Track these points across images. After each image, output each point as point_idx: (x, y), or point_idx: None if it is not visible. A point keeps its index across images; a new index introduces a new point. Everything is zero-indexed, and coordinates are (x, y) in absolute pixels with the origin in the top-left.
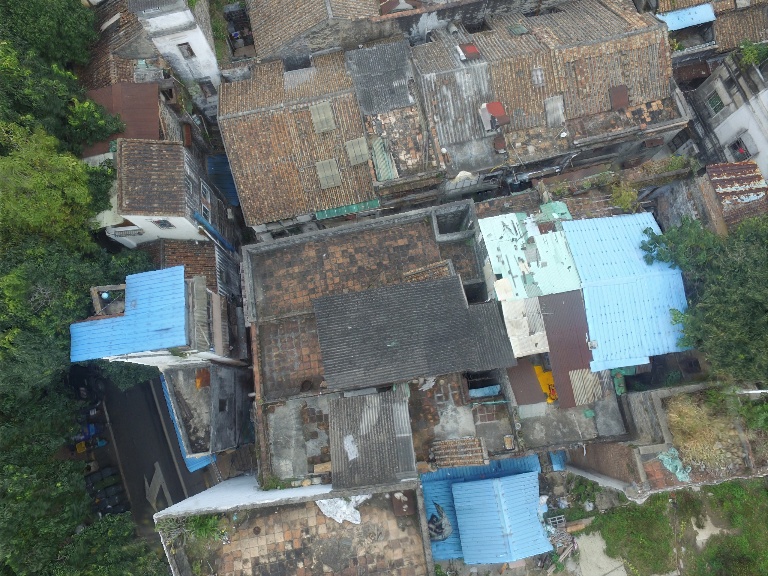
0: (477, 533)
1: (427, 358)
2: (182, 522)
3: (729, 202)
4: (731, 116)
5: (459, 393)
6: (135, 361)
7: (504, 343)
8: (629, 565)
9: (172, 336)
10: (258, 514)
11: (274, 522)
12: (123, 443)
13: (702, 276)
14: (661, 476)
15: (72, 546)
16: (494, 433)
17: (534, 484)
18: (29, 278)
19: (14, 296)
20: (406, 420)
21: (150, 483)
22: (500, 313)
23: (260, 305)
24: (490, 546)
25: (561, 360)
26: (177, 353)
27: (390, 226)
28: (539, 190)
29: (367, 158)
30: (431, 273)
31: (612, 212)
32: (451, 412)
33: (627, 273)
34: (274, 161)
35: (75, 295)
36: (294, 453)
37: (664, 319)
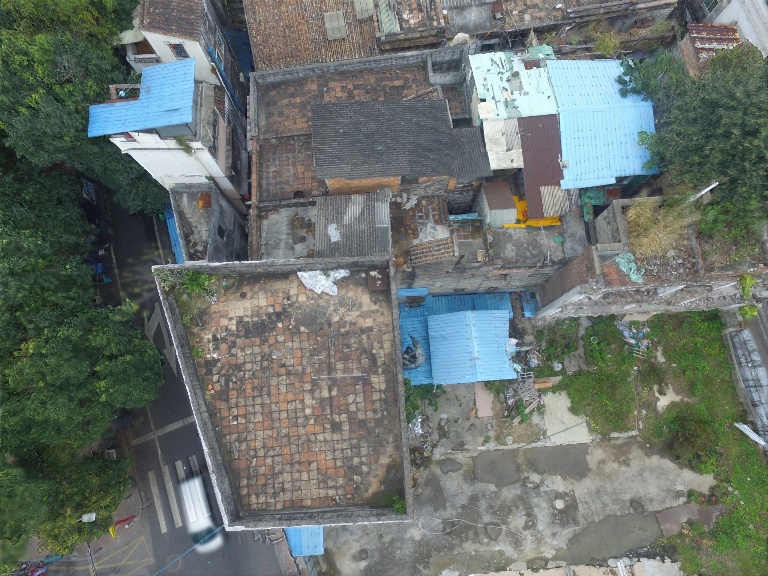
0: (447, 358)
1: (410, 163)
2: (177, 273)
3: (706, 56)
4: (723, 11)
5: (439, 214)
6: (145, 164)
7: (482, 158)
8: (591, 422)
9: (180, 115)
10: (245, 282)
11: (259, 289)
12: (127, 283)
13: (670, 102)
14: (616, 277)
15: (76, 318)
16: (468, 250)
17: (504, 322)
18: (57, 49)
19: (43, 61)
20: (386, 215)
21: (149, 320)
22: (481, 135)
23: (262, 129)
24: (458, 368)
25: (534, 176)
26: (183, 143)
27: (388, 68)
28: (529, 43)
29: (372, 13)
30: (421, 99)
31: (594, 57)
32: (430, 229)
33: (602, 102)
34: (286, 10)
35: (95, 88)
36: (283, 253)
37: (633, 145)
